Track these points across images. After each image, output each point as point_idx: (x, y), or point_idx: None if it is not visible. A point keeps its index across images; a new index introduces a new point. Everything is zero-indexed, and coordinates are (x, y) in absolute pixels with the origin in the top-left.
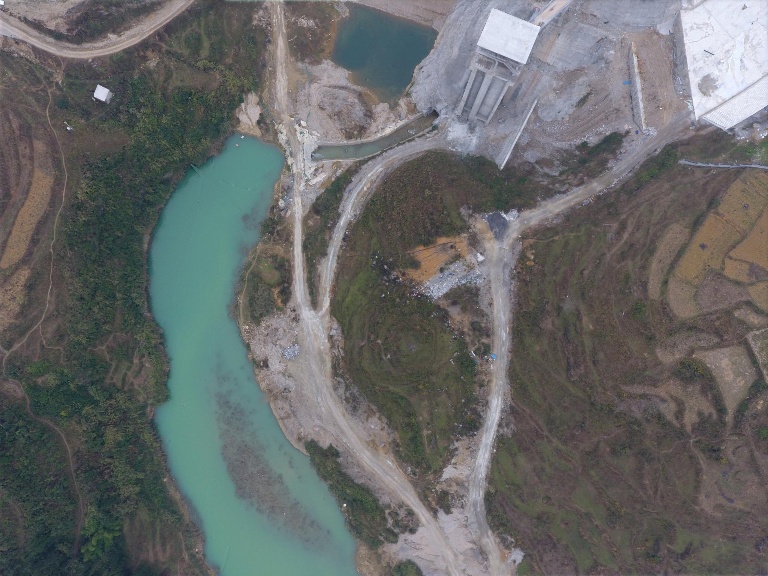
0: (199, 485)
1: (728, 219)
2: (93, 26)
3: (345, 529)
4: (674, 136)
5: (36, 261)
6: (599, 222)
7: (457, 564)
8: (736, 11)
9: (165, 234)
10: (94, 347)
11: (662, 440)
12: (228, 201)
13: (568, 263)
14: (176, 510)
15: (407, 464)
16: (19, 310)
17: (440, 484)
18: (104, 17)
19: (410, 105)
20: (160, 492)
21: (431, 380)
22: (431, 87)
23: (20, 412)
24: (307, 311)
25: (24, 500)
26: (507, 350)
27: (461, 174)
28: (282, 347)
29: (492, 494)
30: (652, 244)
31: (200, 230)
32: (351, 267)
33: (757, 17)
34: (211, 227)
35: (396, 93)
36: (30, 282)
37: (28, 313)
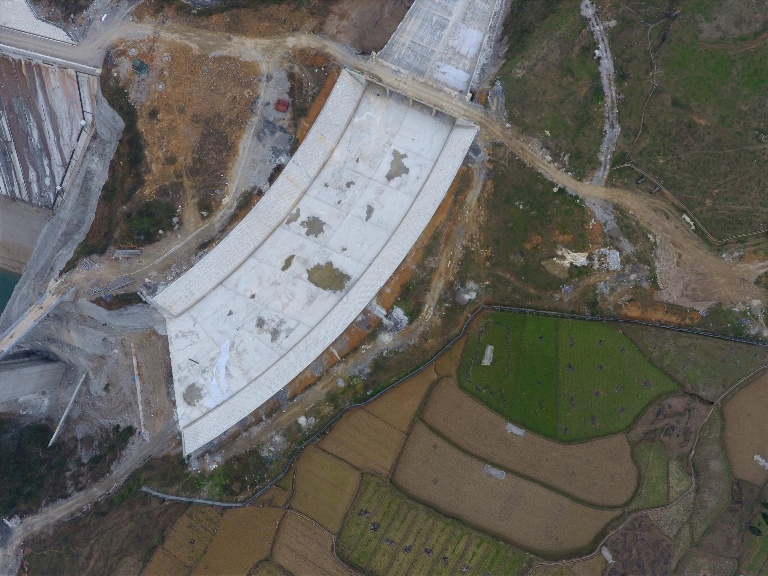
0: None
1: (174, 555)
2: None
3: None
4: (164, 444)
5: None
6: (73, 544)
7: None
8: (222, 317)
9: None
10: None
11: None
12: None
13: None
14: None
15: None
16: None
17: None
18: None
19: None
20: None
21: None
22: None
23: None
24: None
25: None
26: None
27: None
28: None
29: None
30: None
31: None
32: None
33: (243, 323)
34: None
35: None
36: None
37: None
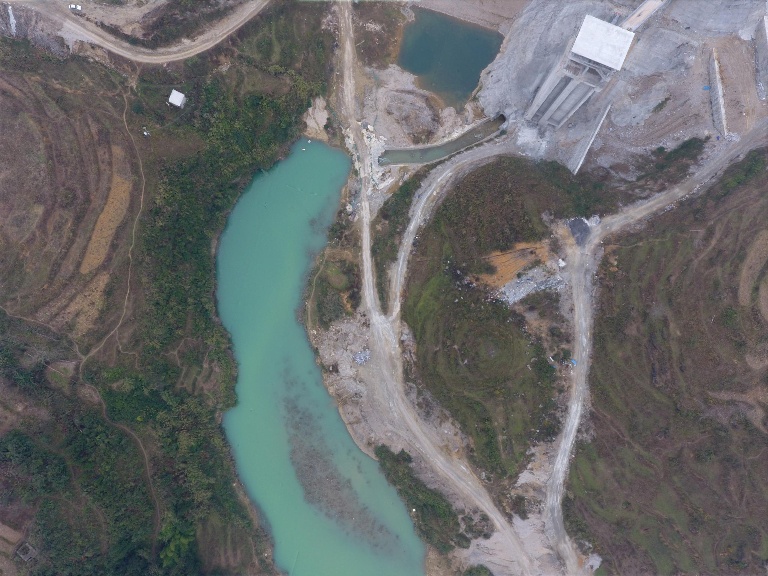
0: (267, 490)
1: None
2: (168, 31)
3: (414, 534)
4: (757, 142)
5: (115, 266)
6: (686, 228)
7: (532, 569)
8: None
9: (232, 239)
10: (166, 352)
11: (749, 446)
12: (297, 206)
13: (654, 269)
14: (246, 515)
15: (481, 469)
16: (98, 315)
17: (515, 489)
18: (179, 22)
19: (477, 109)
20: (230, 497)
21: (507, 385)
22: (501, 92)
23: (97, 417)
24: (377, 316)
25: (107, 506)
26: (587, 356)
27: (539, 179)
28: (353, 352)
29: (571, 500)
30: (742, 250)
31: (266, 234)
32: (422, 272)
33: None
34: (278, 232)
35: (462, 97)
36: (109, 287)
37: (106, 318)
